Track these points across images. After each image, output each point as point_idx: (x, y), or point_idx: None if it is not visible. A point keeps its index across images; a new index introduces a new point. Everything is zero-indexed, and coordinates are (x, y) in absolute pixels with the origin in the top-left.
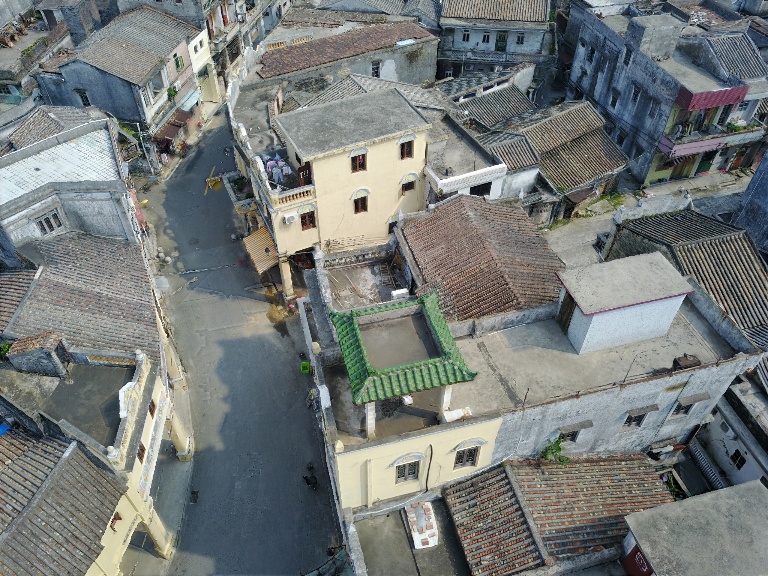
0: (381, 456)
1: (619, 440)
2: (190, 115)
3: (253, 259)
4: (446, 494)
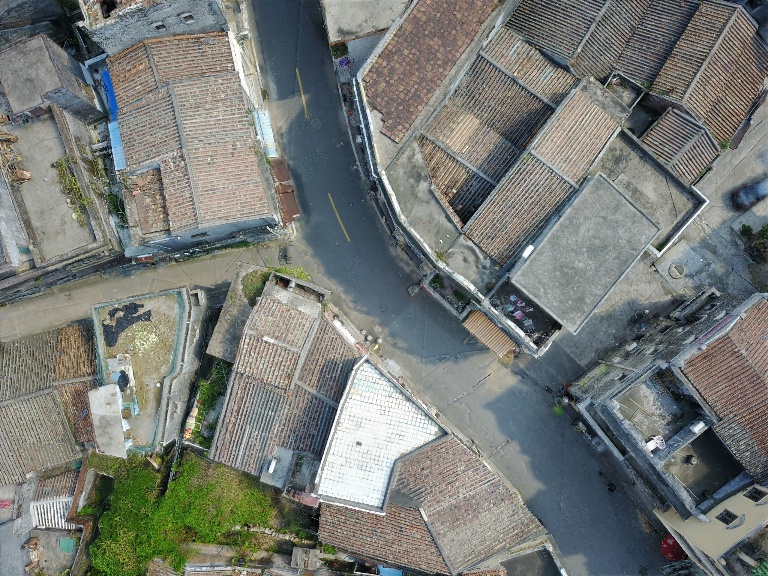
0: None
1: None
2: None
3: (486, 344)
4: None
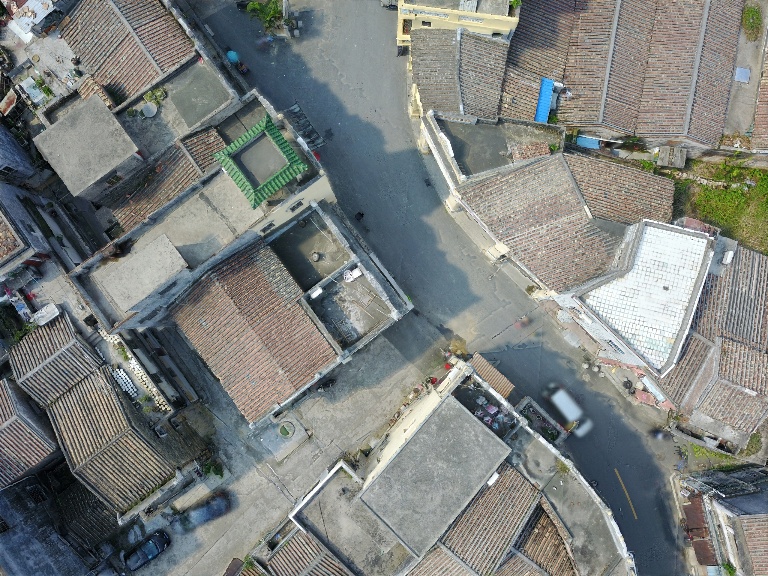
0: None
1: None
2: None
3: None
4: None
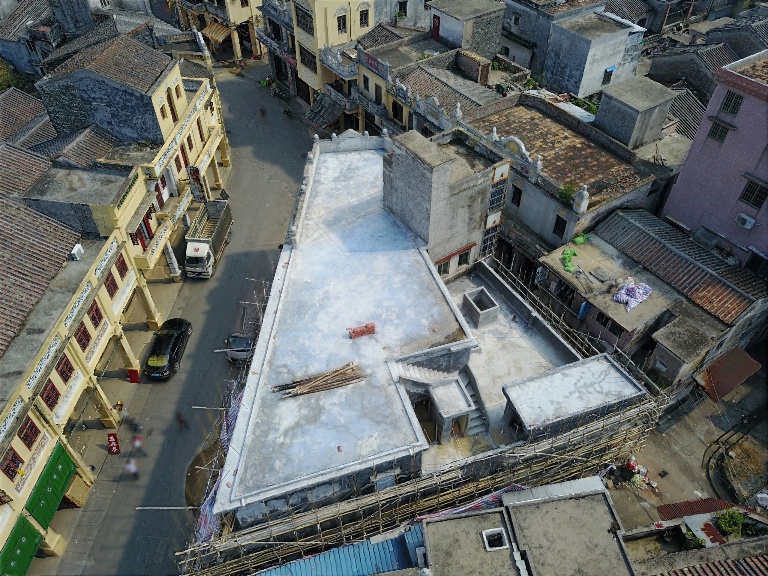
0: (331, 7)
1: (425, 19)
2: None
3: (213, 37)
4: (359, 42)
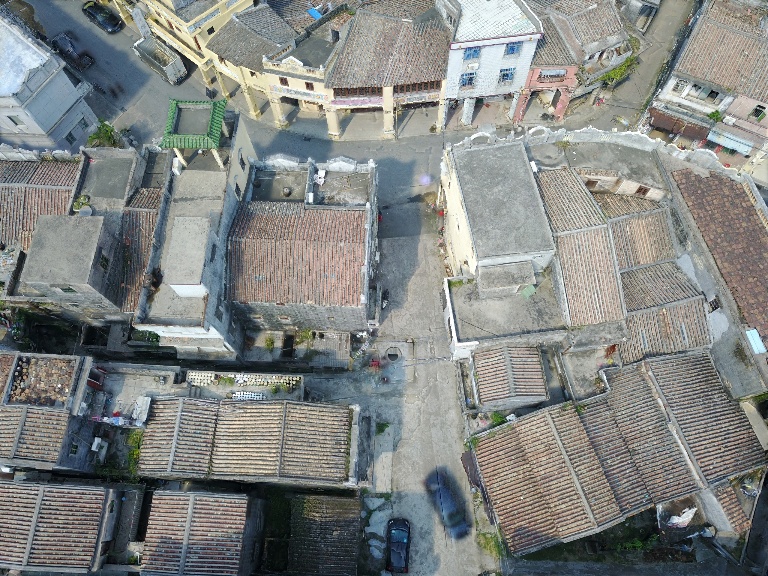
0: None
1: None
2: (729, 151)
3: None
4: None
